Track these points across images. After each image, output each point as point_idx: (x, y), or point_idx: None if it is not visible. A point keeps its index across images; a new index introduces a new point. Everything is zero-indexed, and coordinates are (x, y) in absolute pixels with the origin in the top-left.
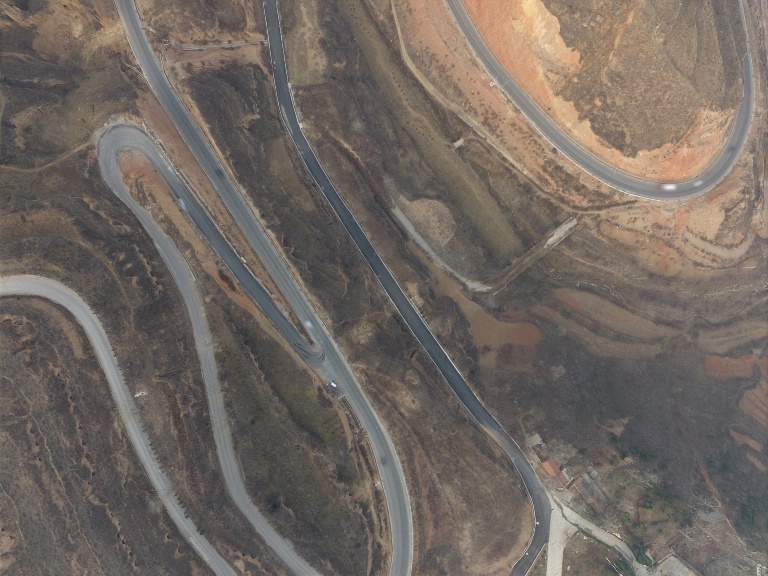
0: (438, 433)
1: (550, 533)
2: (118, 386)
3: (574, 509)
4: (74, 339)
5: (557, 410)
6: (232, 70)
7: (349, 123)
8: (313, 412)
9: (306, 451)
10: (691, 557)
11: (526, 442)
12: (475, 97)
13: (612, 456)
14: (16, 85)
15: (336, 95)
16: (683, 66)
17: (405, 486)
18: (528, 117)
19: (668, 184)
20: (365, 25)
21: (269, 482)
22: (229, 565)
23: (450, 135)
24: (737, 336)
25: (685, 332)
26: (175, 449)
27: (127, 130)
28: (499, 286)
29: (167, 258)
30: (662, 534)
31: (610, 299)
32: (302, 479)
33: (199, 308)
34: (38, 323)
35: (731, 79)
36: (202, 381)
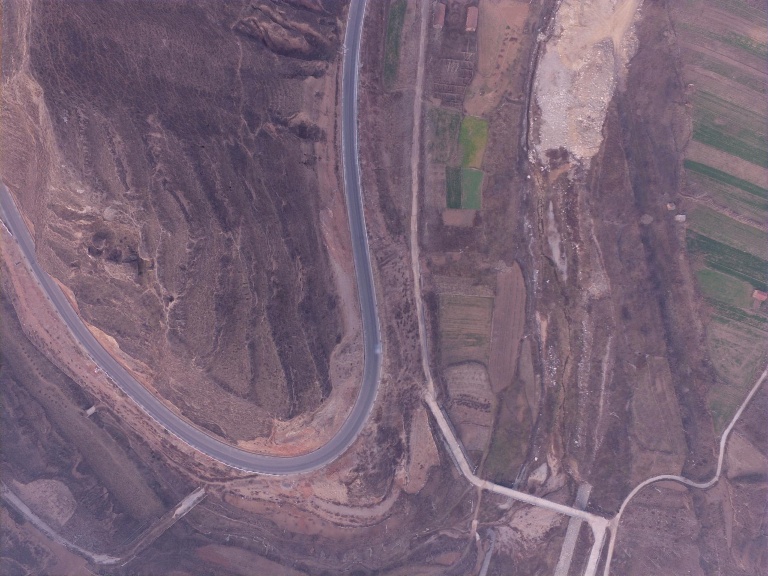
0: None
1: None
2: None
3: None
4: None
5: None
6: None
7: None
8: None
9: None
10: None
11: None
12: (86, 379)
13: None
14: None
15: None
16: (236, 386)
17: None
18: (136, 401)
19: (288, 458)
20: None
21: None
22: None
23: (85, 401)
24: None
25: None
26: None
27: None
28: (128, 557)
29: None
30: None
31: (262, 551)
32: None
33: None
34: None
35: (307, 383)
36: None
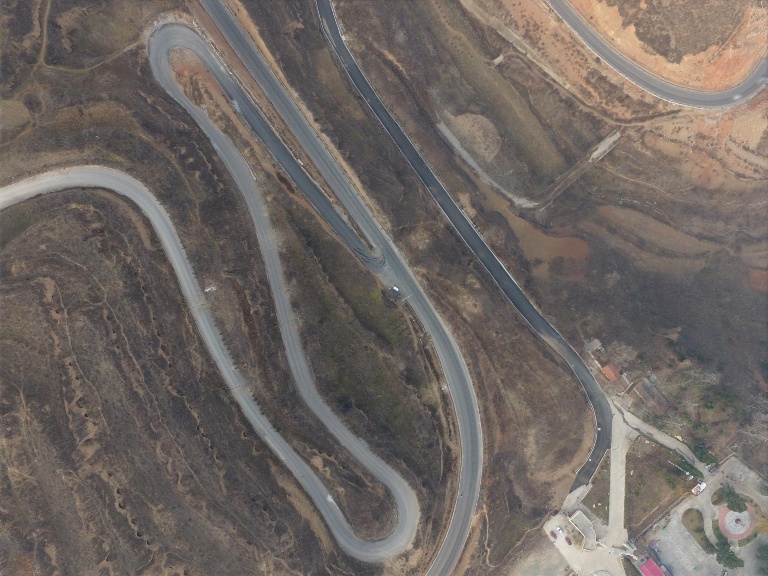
0: (501, 337)
1: (612, 438)
2: (187, 280)
3: (635, 413)
4: (142, 230)
5: (614, 315)
6: None
7: (392, 35)
8: (379, 314)
9: (375, 351)
10: (751, 457)
11: (585, 348)
12: (516, 8)
13: (670, 360)
14: None
15: (378, 6)
16: None
17: (472, 388)
18: (571, 26)
19: (711, 92)
20: None
21: (339, 384)
22: (306, 463)
23: (489, 52)
24: None
25: (728, 246)
26: (247, 345)
27: (177, 29)
28: (545, 202)
29: (226, 158)
30: (723, 435)
31: (653, 216)
32: (372, 380)
33: (261, 207)
34: (106, 211)
35: None
36: (267, 282)
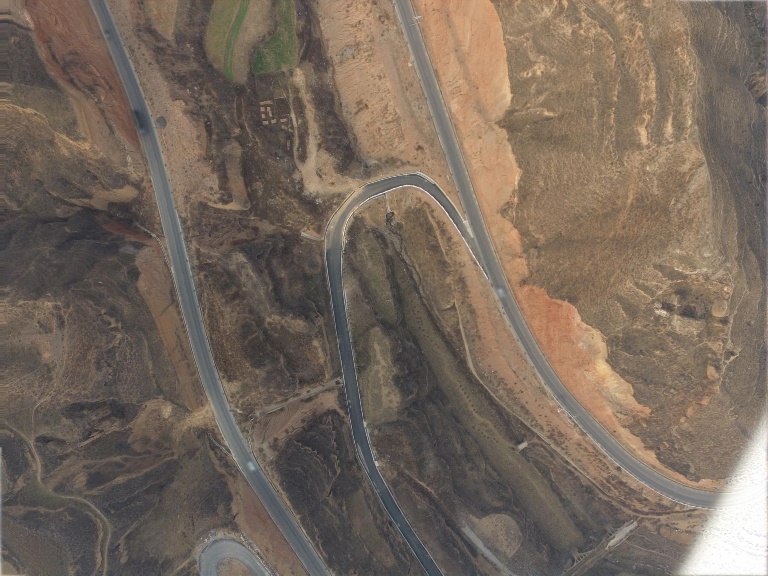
0: None
1: None
2: None
3: None
4: None
5: None
6: (314, 433)
7: (422, 456)
8: None
9: None
10: None
11: None
12: (542, 418)
13: None
14: (119, 506)
15: (410, 432)
16: (753, 433)
17: None
18: (594, 439)
19: (727, 493)
20: (432, 337)
21: None
22: None
23: (514, 436)
24: None
25: None
26: None
27: (226, 543)
28: None
29: None
30: None
31: None
32: None
33: None
34: None
35: None
36: None
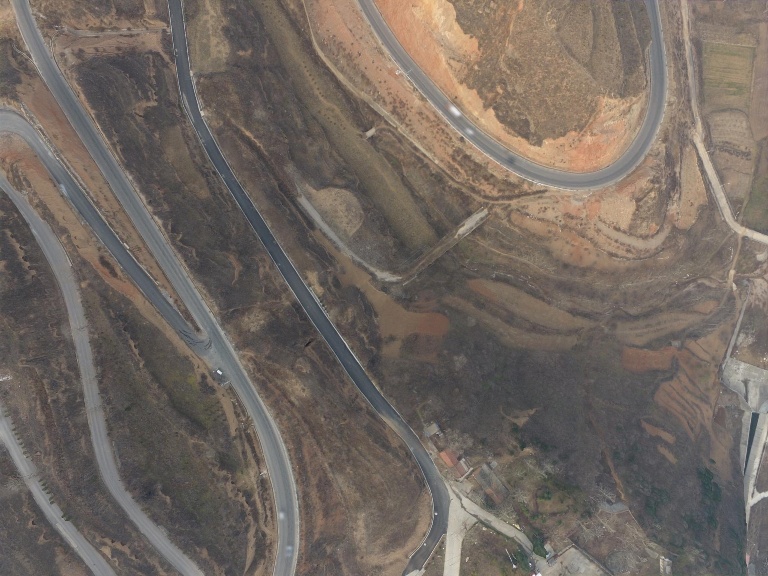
0: (328, 422)
1: (449, 524)
2: None
3: (472, 500)
4: None
5: (457, 400)
6: (127, 57)
7: (252, 111)
8: (194, 399)
9: (185, 438)
10: (593, 549)
11: (424, 432)
12: (382, 86)
13: (513, 446)
14: None
15: (238, 83)
16: (578, 53)
17: (291, 474)
18: (435, 106)
19: (578, 173)
20: (275, 14)
21: (147, 469)
22: (98, 552)
23: (362, 124)
24: (656, 328)
25: (603, 323)
26: (41, 434)
27: (6, 115)
28: (409, 276)
29: (43, 243)
30: (562, 525)
31: (527, 290)
32: (180, 466)
33: (75, 293)
34: None
35: (632, 67)
36: (77, 367)
